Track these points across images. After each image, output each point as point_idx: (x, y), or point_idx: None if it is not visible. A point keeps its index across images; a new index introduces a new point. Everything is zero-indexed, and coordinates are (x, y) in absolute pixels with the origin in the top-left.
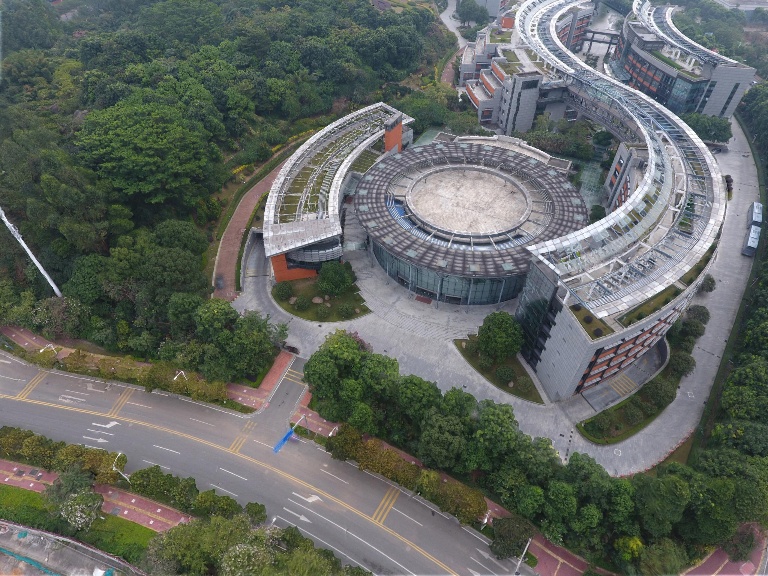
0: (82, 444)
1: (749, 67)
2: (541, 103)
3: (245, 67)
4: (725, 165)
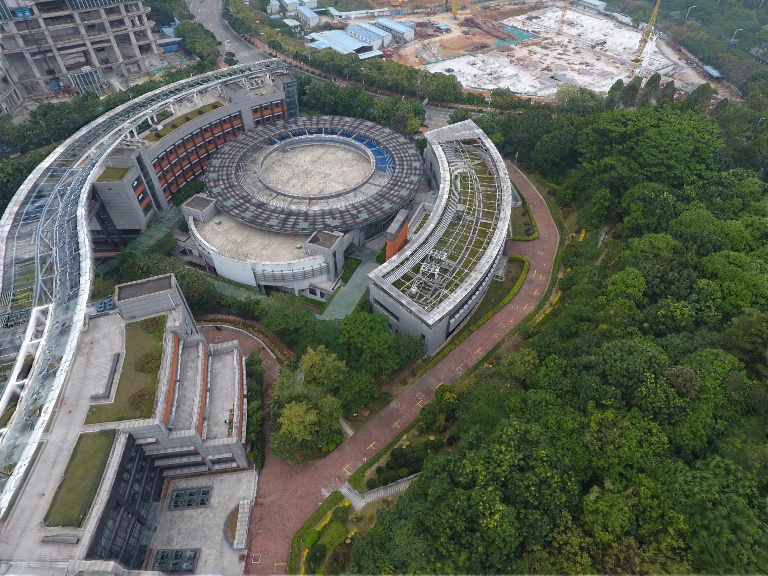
0: (517, 105)
1: None
2: None
3: None
4: None
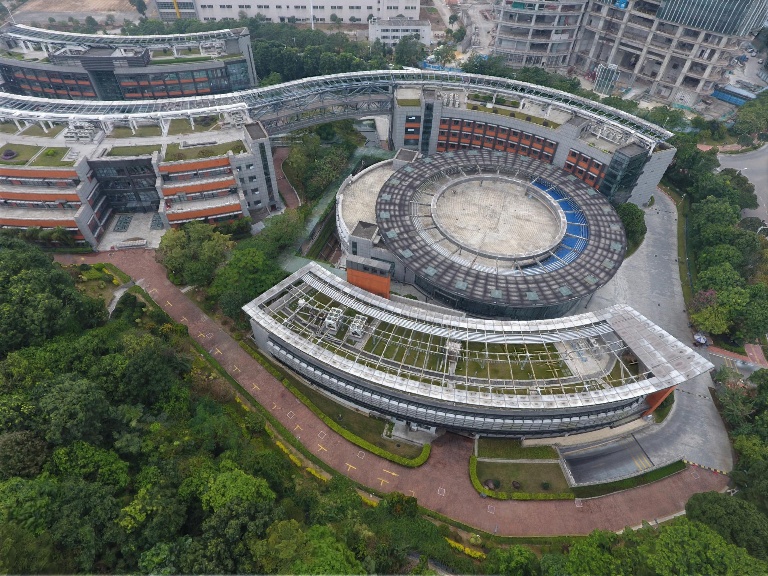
0: None
1: (242, 28)
2: None
3: None
4: None
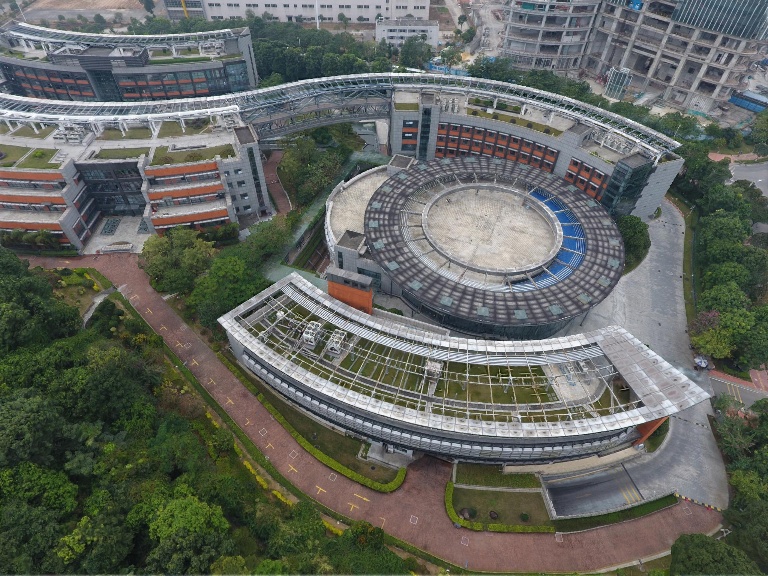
0: None
1: None
2: None
3: None
4: None
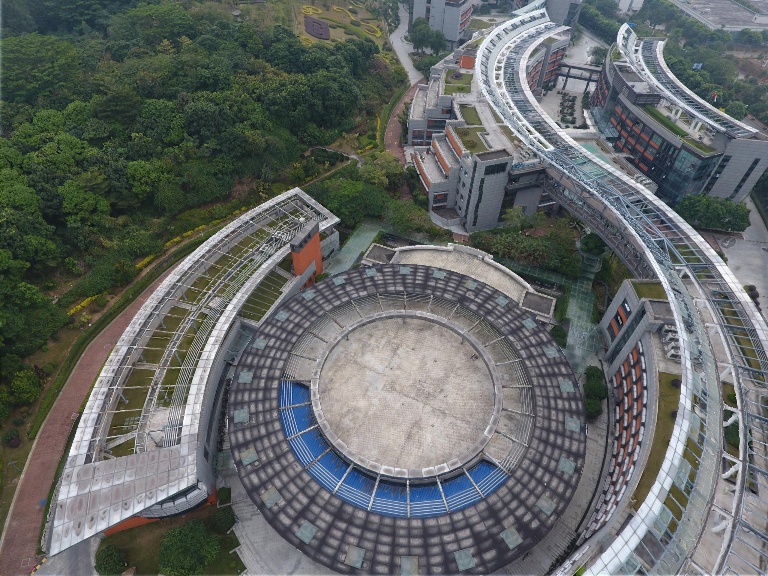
0: None
1: None
2: (511, 190)
3: (106, 138)
4: (744, 266)
